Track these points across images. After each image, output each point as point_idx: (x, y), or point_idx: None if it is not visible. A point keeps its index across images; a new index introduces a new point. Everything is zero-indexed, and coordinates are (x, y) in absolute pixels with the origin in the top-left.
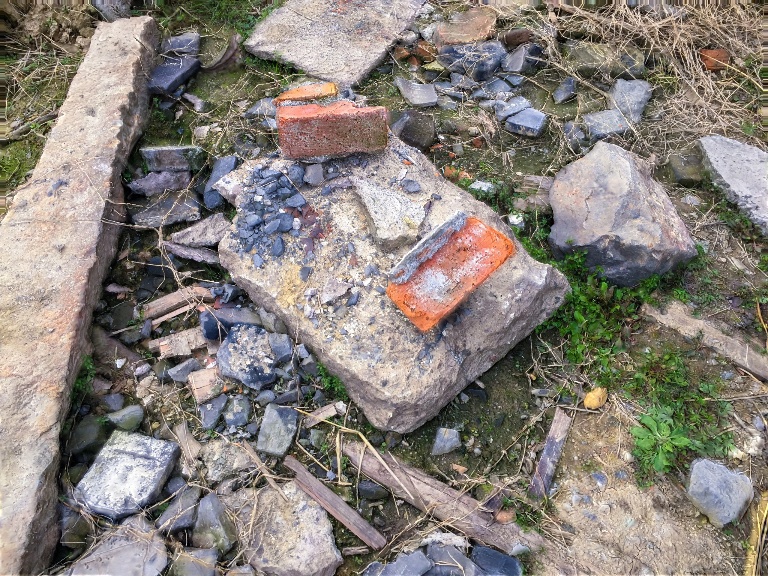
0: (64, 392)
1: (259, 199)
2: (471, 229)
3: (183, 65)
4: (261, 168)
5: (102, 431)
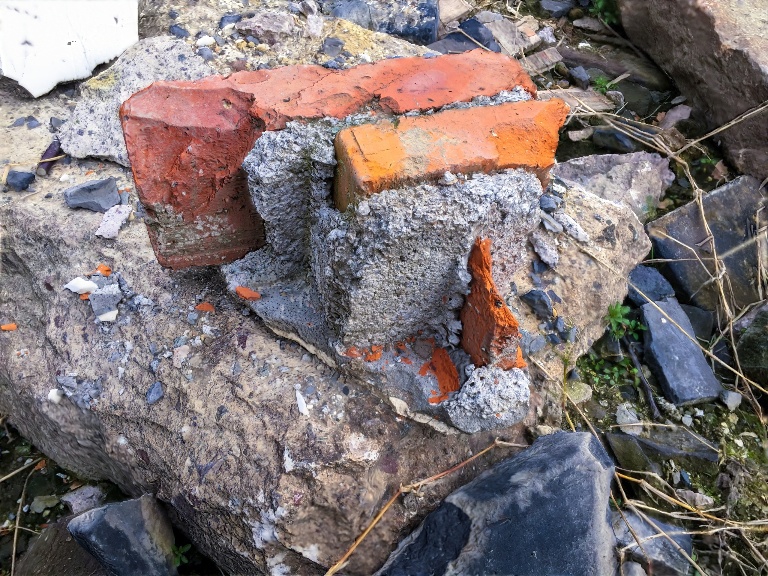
0: None
1: None
2: None
3: None
4: None
5: None
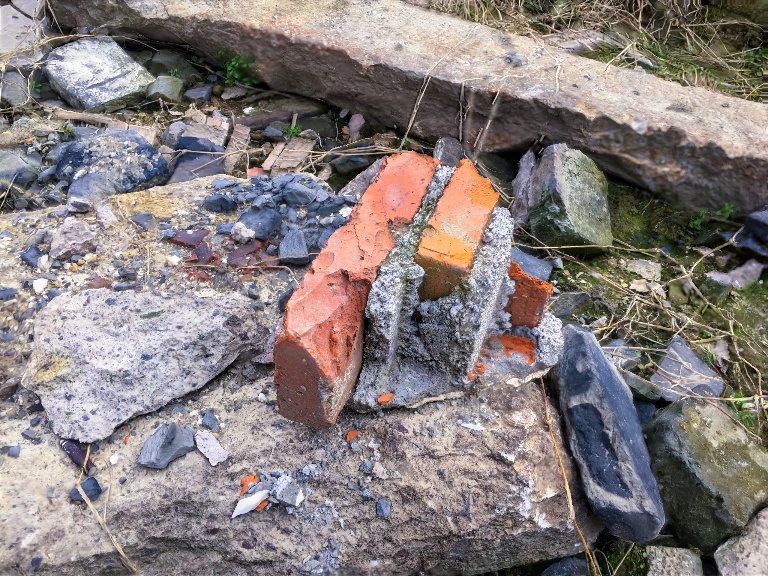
0: (195, 20)
1: (344, 212)
2: None
3: None
4: None
5: (161, 69)
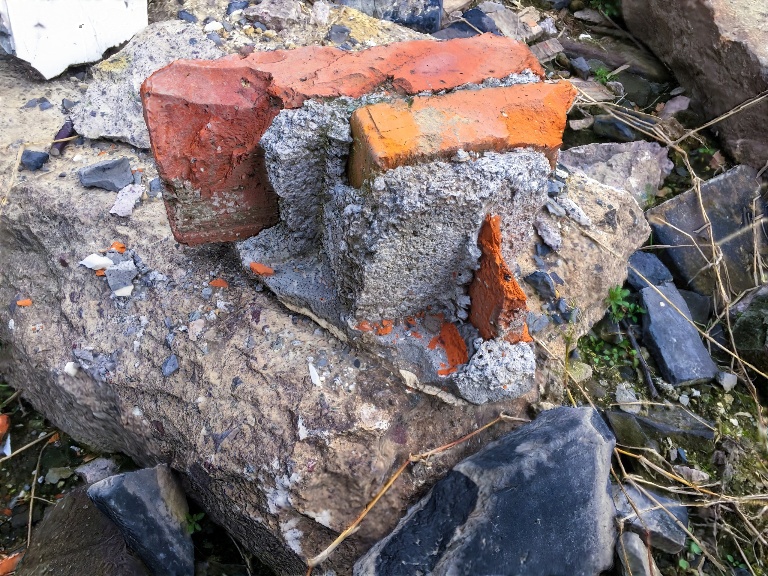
0: None
1: None
2: None
3: None
4: None
5: None
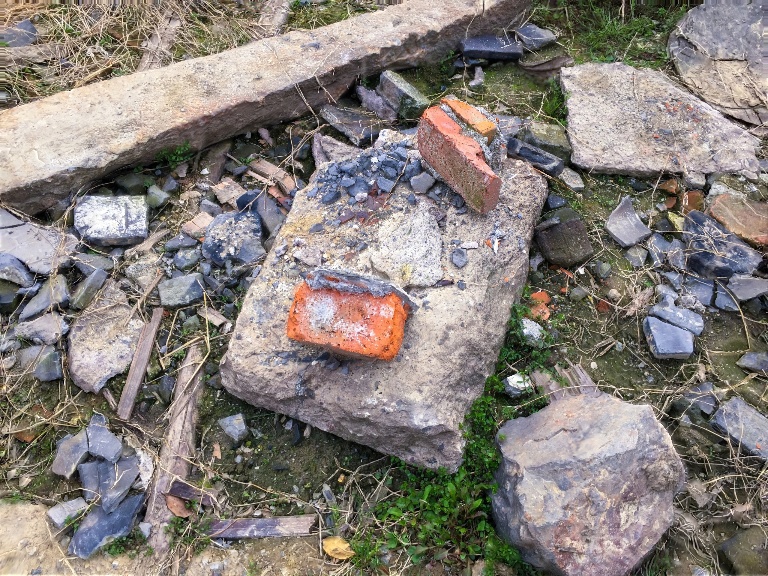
0: (140, 145)
1: (374, 161)
2: (384, 308)
3: (506, 47)
4: (408, 145)
5: (137, 188)
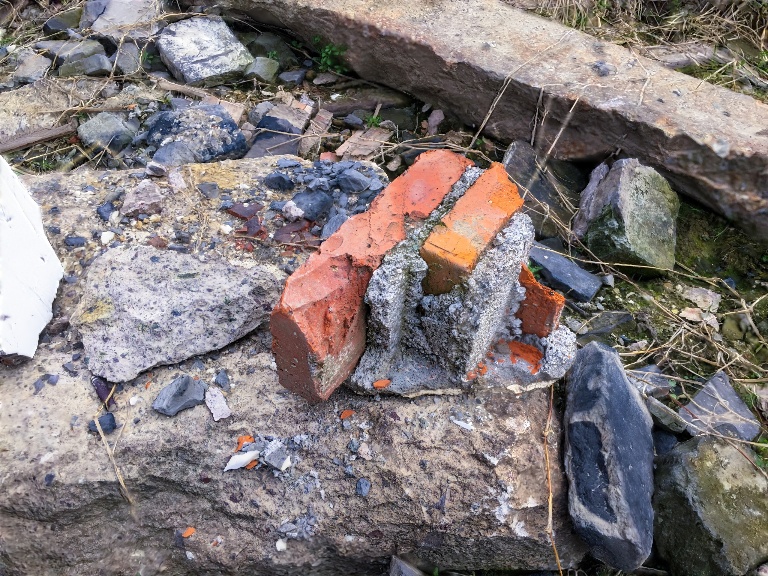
0: (297, 6)
1: None
2: None
3: None
4: None
5: (261, 50)
